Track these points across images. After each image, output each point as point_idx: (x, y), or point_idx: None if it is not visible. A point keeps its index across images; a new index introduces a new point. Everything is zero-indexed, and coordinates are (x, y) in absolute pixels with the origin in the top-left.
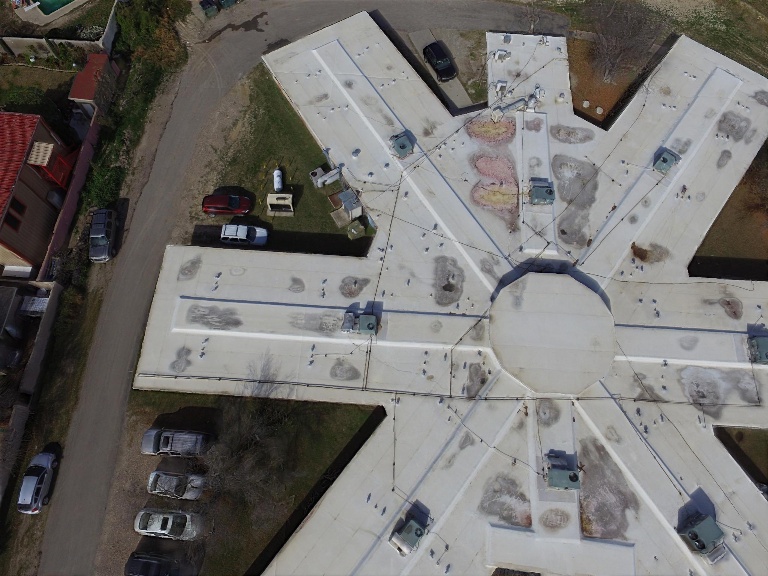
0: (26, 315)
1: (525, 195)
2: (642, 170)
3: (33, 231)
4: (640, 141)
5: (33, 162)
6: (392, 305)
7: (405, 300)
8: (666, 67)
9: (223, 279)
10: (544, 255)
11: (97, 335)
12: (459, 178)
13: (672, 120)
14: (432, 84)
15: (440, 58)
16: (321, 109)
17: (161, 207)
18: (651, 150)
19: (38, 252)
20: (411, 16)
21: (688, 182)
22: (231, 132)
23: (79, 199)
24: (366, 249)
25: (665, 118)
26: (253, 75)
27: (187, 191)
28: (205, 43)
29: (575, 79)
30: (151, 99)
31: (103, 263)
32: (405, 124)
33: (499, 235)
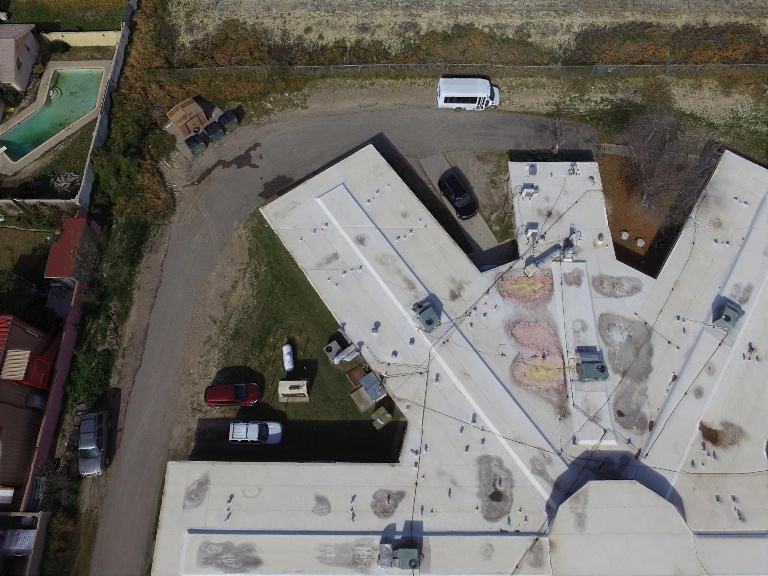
0: (11, 555)
1: (572, 370)
2: (700, 327)
3: (13, 448)
4: (694, 289)
5: (7, 377)
6: (433, 525)
7: (448, 517)
8: (713, 192)
9: (236, 504)
10: (601, 446)
11: (94, 570)
12: (495, 352)
13: (727, 260)
14: (451, 222)
15: (459, 194)
16: (332, 273)
17: (158, 398)
18: (708, 300)
19: (20, 468)
20: (420, 138)
21: (754, 338)
22: (231, 297)
23: (64, 394)
24: (394, 437)
25: (719, 257)
26: (250, 223)
27: (186, 376)
28: (194, 186)
29: (609, 204)
30: (138, 260)
31: (96, 475)
32: (428, 286)
33: (547, 423)
